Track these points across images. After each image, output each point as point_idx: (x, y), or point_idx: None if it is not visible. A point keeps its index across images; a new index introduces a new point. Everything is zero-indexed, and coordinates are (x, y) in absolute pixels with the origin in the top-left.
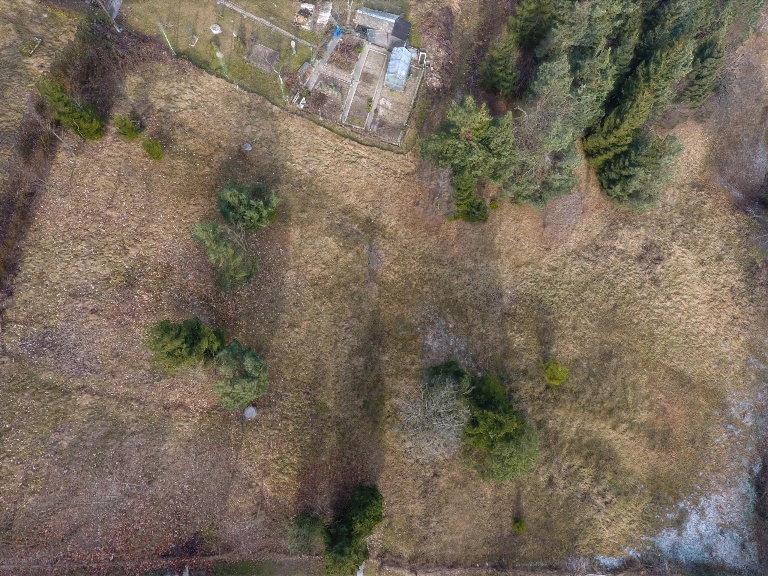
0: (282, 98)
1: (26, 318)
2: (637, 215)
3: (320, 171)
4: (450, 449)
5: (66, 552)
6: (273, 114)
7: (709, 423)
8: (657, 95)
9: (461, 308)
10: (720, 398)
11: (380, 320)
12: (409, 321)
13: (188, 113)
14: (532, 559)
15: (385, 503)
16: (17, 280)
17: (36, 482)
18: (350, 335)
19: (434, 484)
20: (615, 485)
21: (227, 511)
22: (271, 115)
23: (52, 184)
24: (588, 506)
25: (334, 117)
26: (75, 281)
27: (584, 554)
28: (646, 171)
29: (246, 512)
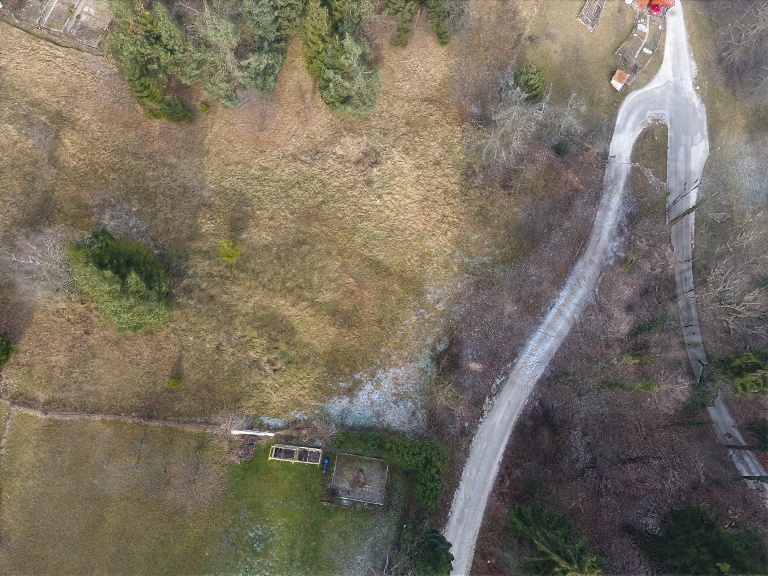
0: None
1: None
2: (362, 125)
3: (10, 67)
4: None
5: None
6: None
7: (400, 307)
8: (343, 1)
9: (151, 196)
10: (417, 286)
11: (53, 199)
12: (85, 202)
13: None
14: (188, 414)
15: (27, 354)
16: None
17: None
18: (15, 209)
19: (83, 341)
20: (288, 355)
21: None
22: None
23: None
24: (254, 371)
25: (31, 20)
26: None
27: (247, 414)
28: (343, 75)
29: None
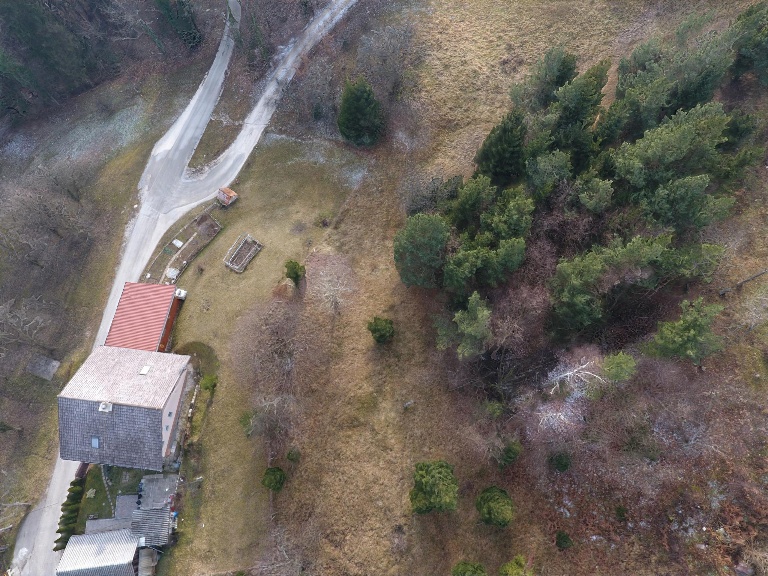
0: None
1: None
2: None
3: None
4: None
5: None
6: None
7: None
8: None
9: None
10: None
11: None
12: None
13: None
14: None
15: None
16: None
17: None
18: None
19: None
20: None
21: None
22: None
23: None
24: None
25: None
26: None
27: None
28: None
29: None
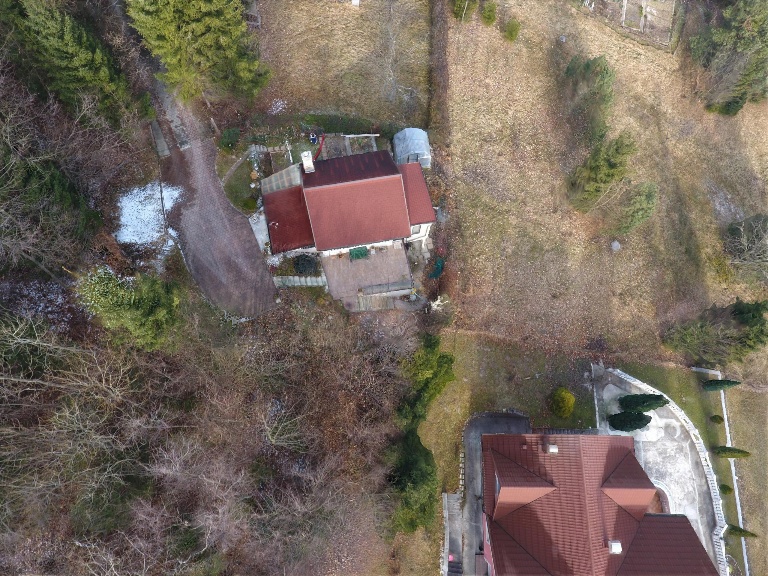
0: (576, 2)
1: (461, 154)
2: None
3: (612, 64)
4: (754, 292)
5: (529, 333)
6: (573, 15)
7: None
8: None
9: (731, 184)
10: None
11: (680, 186)
12: (701, 189)
13: (517, 8)
14: None
15: None
16: (450, 124)
17: (501, 277)
18: (664, 195)
19: None
20: None
21: (615, 322)
22: (571, 15)
23: (448, 54)
24: None
25: (616, 20)
26: (483, 130)
27: None
28: None
29: (627, 324)
